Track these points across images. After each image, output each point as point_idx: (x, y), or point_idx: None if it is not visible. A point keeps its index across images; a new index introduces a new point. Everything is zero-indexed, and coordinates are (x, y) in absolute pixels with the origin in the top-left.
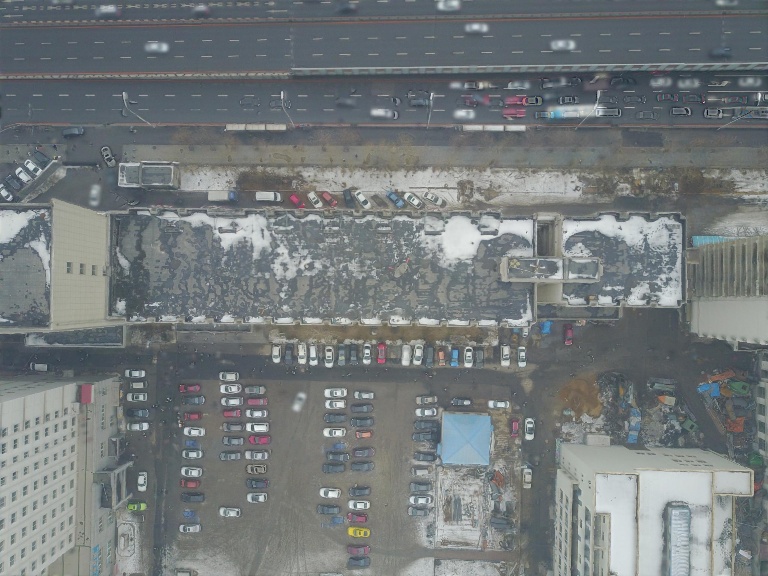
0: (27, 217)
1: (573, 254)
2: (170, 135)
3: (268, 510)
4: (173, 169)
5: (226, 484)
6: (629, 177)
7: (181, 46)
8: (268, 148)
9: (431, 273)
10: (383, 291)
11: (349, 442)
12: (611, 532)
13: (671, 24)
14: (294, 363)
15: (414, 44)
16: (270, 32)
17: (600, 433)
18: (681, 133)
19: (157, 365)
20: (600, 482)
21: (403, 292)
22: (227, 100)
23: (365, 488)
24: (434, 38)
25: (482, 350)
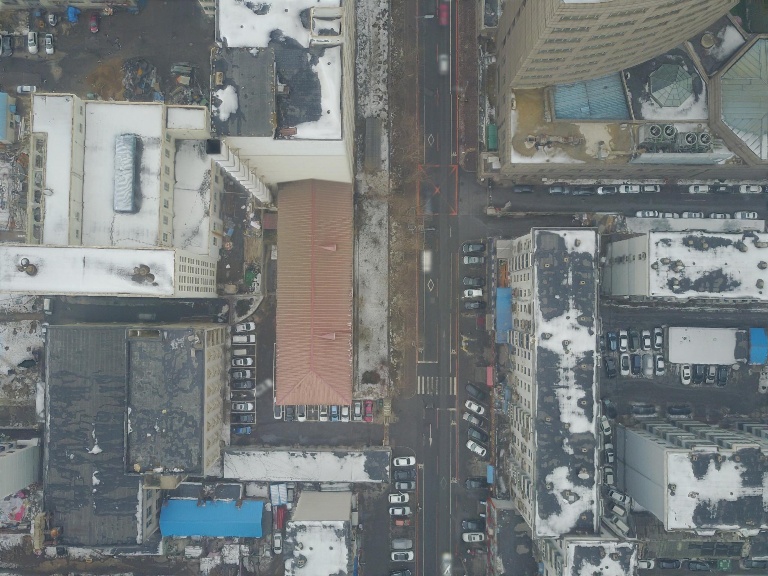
0: None
1: None
2: None
3: None
4: None
5: None
6: None
7: None
8: None
9: None
10: None
11: None
12: (48, 151)
13: None
14: None
15: None
16: None
17: None
18: None
19: None
20: (38, 104)
21: None
22: None
23: None
24: None
25: (10, 37)
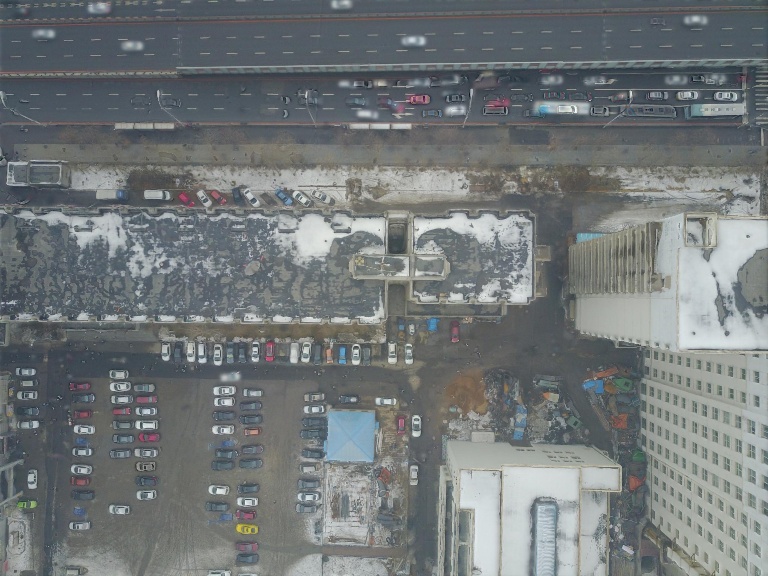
0: None
1: (425, 251)
2: None
3: (158, 507)
4: (61, 168)
5: (116, 482)
6: (516, 175)
7: (70, 45)
8: (158, 147)
9: (285, 271)
10: (237, 289)
11: (238, 439)
12: (475, 528)
13: (553, 22)
14: (184, 361)
15: (300, 43)
16: (158, 31)
17: (486, 430)
18: (568, 131)
19: (48, 363)
20: (464, 478)
21: (257, 290)
22: (118, 99)
23: (253, 485)
24: (320, 37)
25: (369, 347)
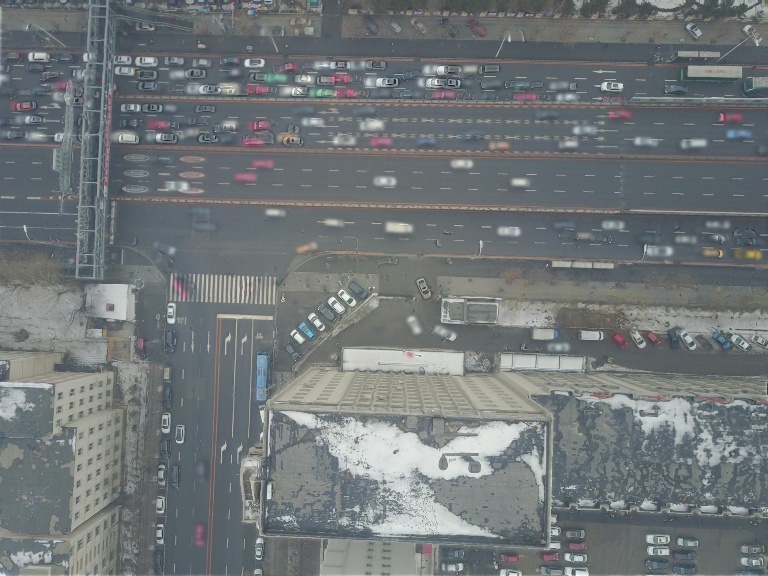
0: (518, 429)
1: None
2: (487, 268)
3: None
4: (498, 306)
5: None
6: None
7: (504, 179)
8: (588, 284)
9: None
10: None
11: None
12: None
13: None
14: None
15: (752, 186)
16: (599, 168)
17: None
18: None
19: None
20: None
21: None
22: (545, 233)
23: None
24: None
25: None
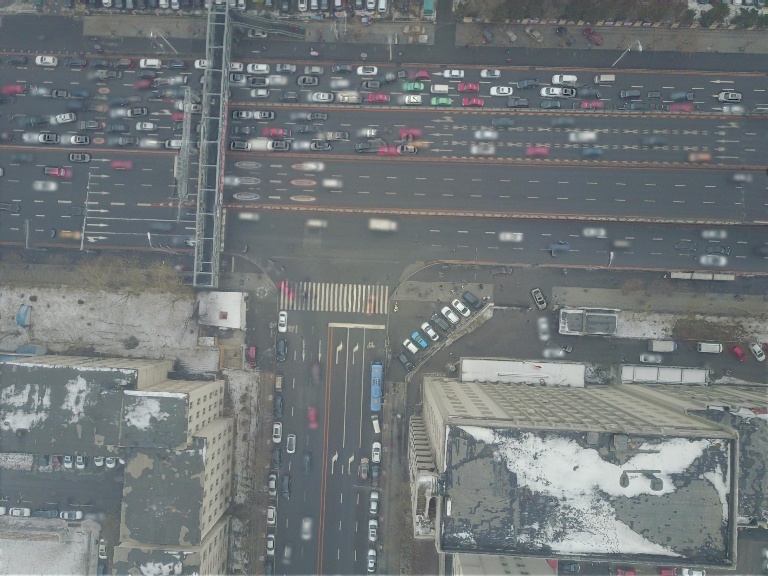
0: (701, 446)
1: None
2: (603, 278)
3: None
4: (617, 318)
5: None
6: None
7: (622, 189)
8: (706, 296)
9: None
10: None
11: None
12: None
13: None
14: None
15: None
16: (720, 179)
17: None
18: None
19: None
20: None
21: None
22: (662, 244)
23: None
24: None
25: None
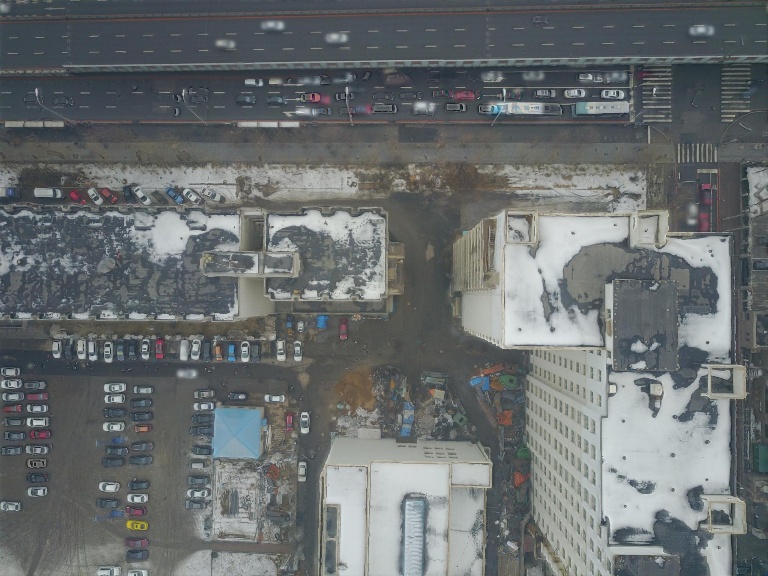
0: None
1: (280, 249)
2: None
3: (49, 504)
4: None
5: (8, 478)
6: (405, 173)
7: None
8: (50, 145)
9: (141, 268)
10: (94, 286)
11: (129, 436)
12: (341, 523)
13: (437, 21)
14: (75, 358)
15: (187, 41)
16: (48, 30)
17: (374, 426)
18: (456, 129)
19: None
20: (331, 474)
21: (114, 287)
22: (11, 97)
23: (143, 482)
24: (207, 35)
25: (258, 345)
